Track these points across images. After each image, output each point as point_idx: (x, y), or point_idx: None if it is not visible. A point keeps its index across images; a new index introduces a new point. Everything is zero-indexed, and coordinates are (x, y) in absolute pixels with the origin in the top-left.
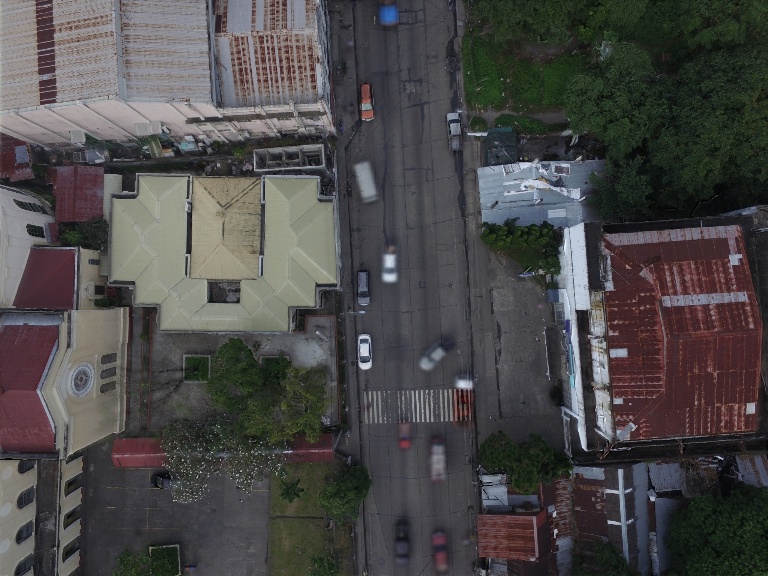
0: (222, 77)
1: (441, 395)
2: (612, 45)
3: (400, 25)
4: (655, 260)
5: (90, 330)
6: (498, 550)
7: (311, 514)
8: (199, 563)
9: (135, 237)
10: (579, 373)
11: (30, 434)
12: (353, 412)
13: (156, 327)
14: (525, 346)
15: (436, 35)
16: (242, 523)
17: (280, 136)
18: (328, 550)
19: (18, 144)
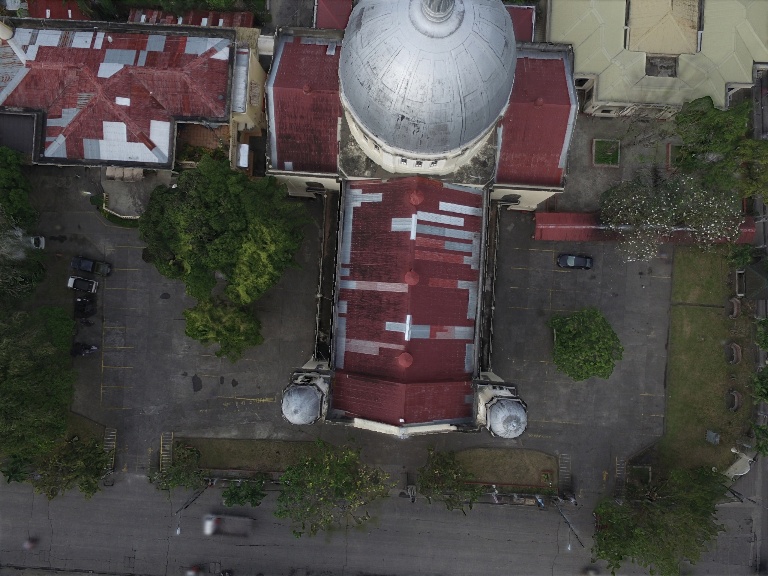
0: None
1: None
2: None
3: None
4: None
5: None
6: None
7: (713, 303)
8: None
9: (584, 3)
10: None
11: (534, 163)
12: (758, 204)
13: None
14: None
15: None
16: (644, 309)
17: None
18: (729, 339)
19: None
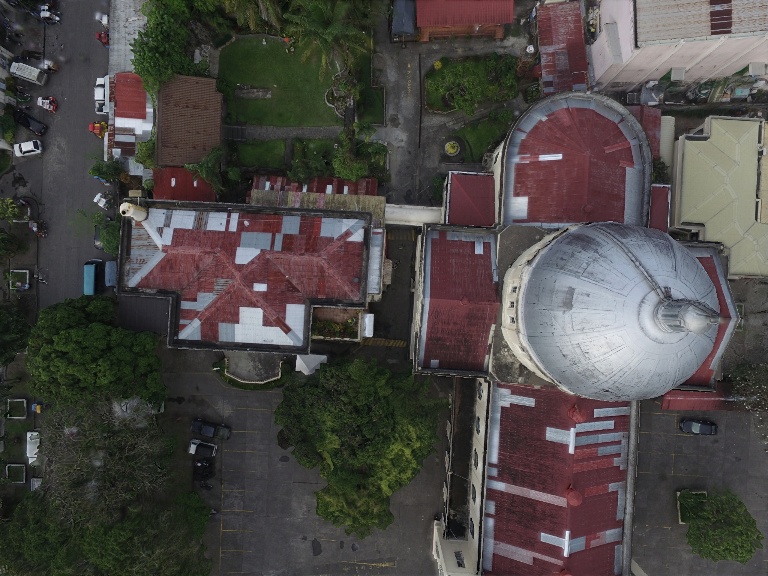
0: None
1: None
2: None
3: None
4: None
5: None
6: None
7: None
8: None
9: (718, 178)
10: None
11: None
12: None
13: None
14: None
15: None
16: (767, 473)
17: None
18: None
19: (577, 82)
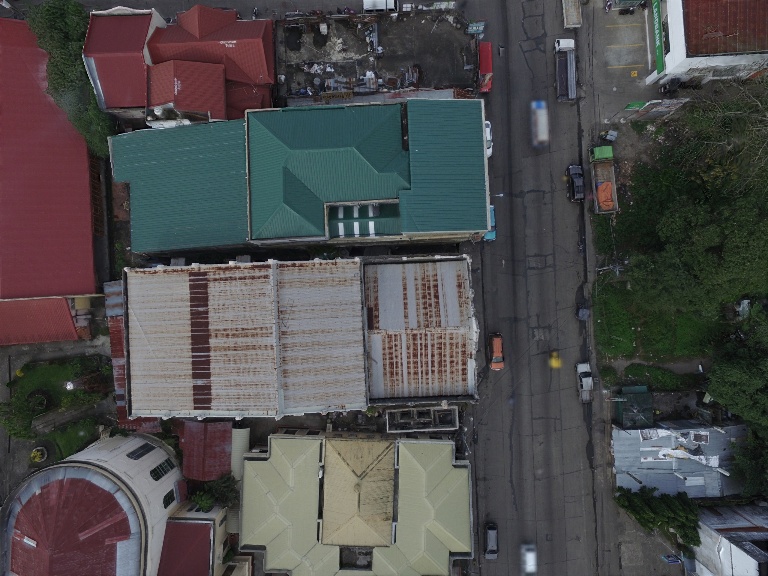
0: (372, 369)
1: None
2: (762, 327)
3: (529, 270)
4: None
5: None
6: None
7: None
8: None
9: (269, 506)
10: None
11: None
12: None
13: (278, 575)
14: None
15: (566, 280)
16: None
17: None
18: None
19: None
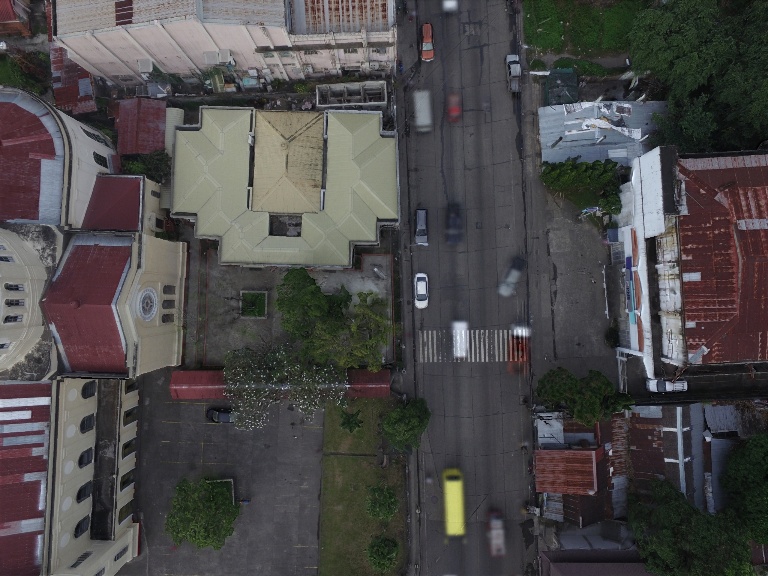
0: (294, 5)
1: (496, 335)
2: None
3: None
4: (730, 185)
5: (156, 256)
6: (556, 485)
7: (365, 452)
8: (252, 498)
9: (199, 168)
10: (647, 302)
11: (100, 353)
12: (408, 351)
13: (213, 263)
14: (581, 288)
15: None
16: (296, 459)
17: (341, 74)
18: None
19: (81, 77)
